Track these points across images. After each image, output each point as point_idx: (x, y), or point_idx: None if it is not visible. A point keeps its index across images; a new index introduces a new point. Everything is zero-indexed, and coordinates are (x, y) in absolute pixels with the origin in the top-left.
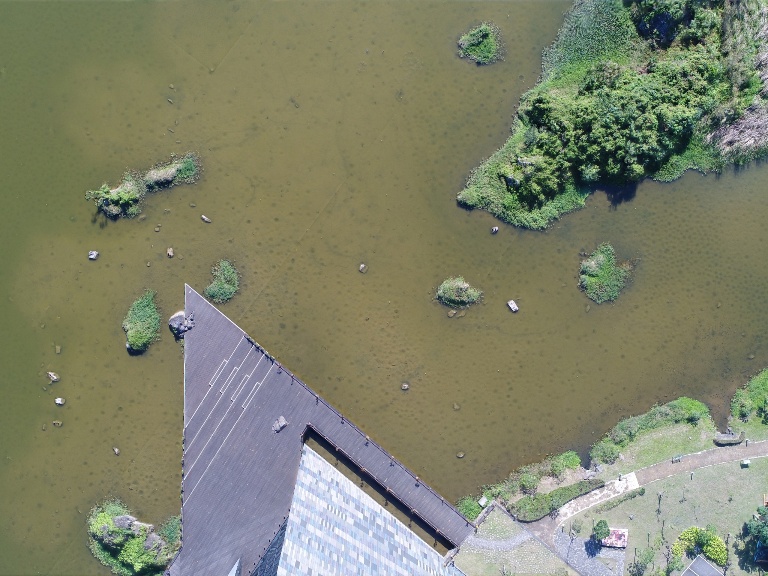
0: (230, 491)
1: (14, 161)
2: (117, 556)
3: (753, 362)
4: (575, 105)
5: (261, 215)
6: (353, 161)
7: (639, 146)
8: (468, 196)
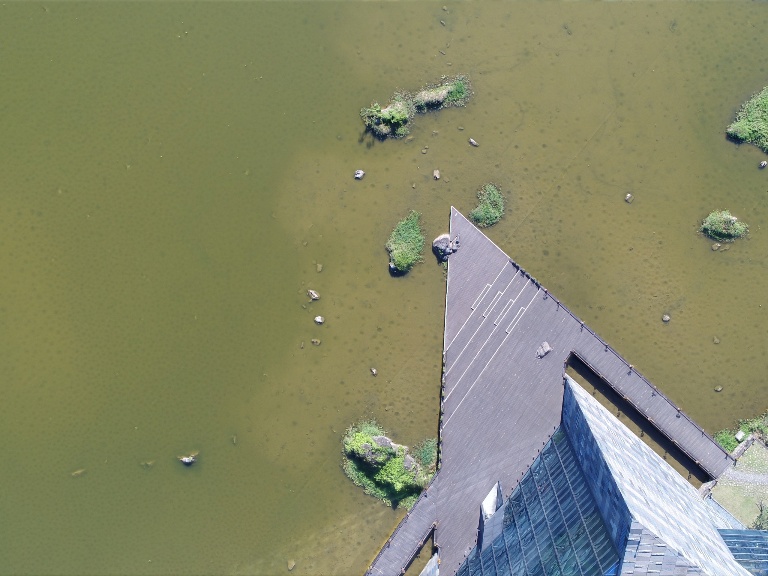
0: (491, 415)
1: (282, 77)
2: (373, 476)
3: None
4: None
5: (529, 141)
6: (623, 90)
7: None
8: (740, 129)
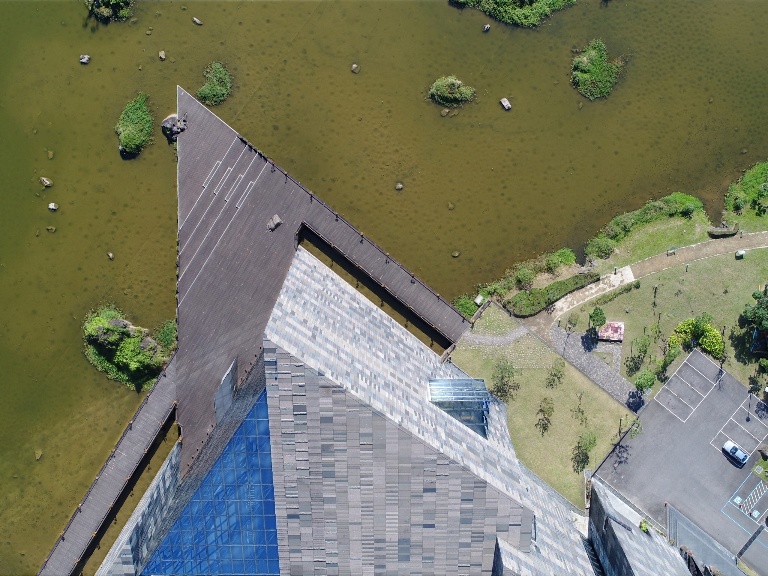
0: (225, 291)
1: None
2: (113, 359)
3: (746, 156)
4: None
5: (252, 17)
6: None
7: None
8: None
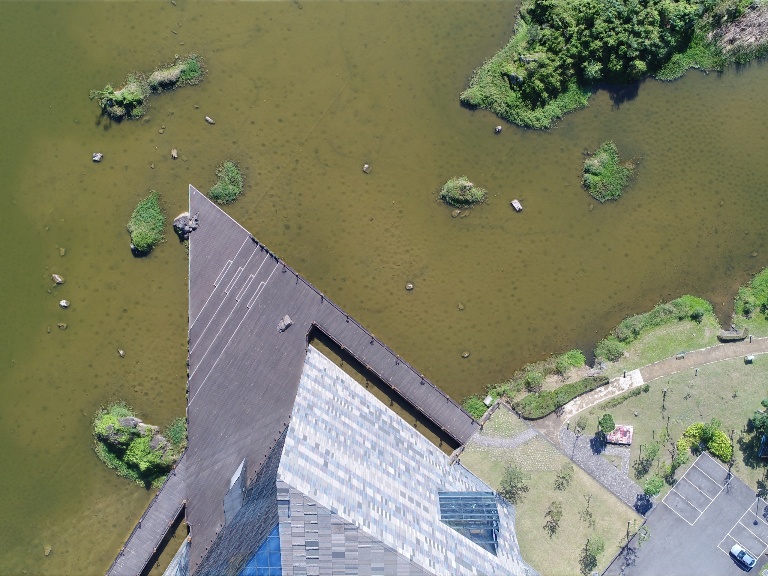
0: (235, 391)
1: (18, 64)
2: (122, 457)
3: (756, 260)
4: (577, 1)
5: (265, 116)
6: (356, 62)
7: (641, 41)
8: (471, 95)
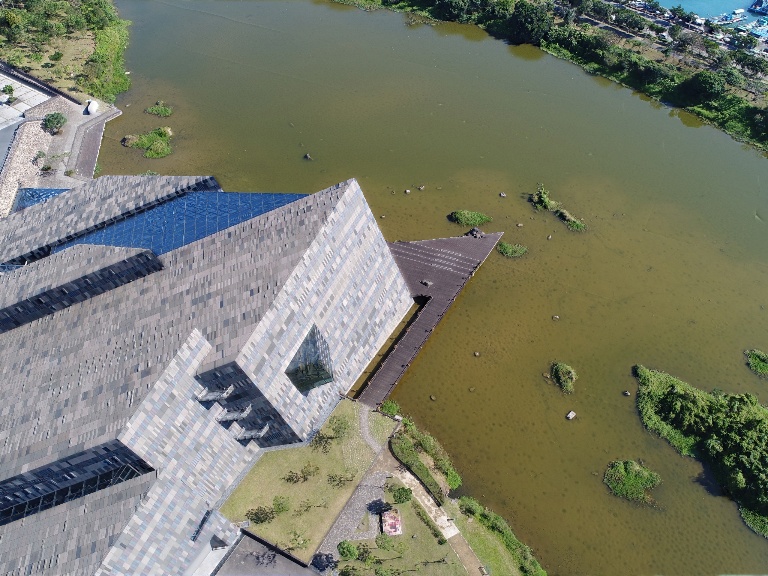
0: None
1: None
2: None
3: None
4: None
5: (566, 262)
6: (630, 303)
7: (761, 468)
8: (644, 369)
